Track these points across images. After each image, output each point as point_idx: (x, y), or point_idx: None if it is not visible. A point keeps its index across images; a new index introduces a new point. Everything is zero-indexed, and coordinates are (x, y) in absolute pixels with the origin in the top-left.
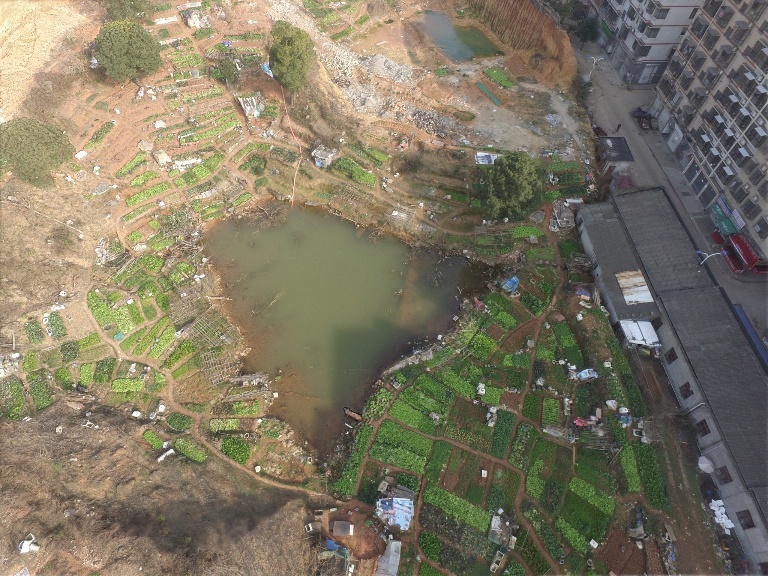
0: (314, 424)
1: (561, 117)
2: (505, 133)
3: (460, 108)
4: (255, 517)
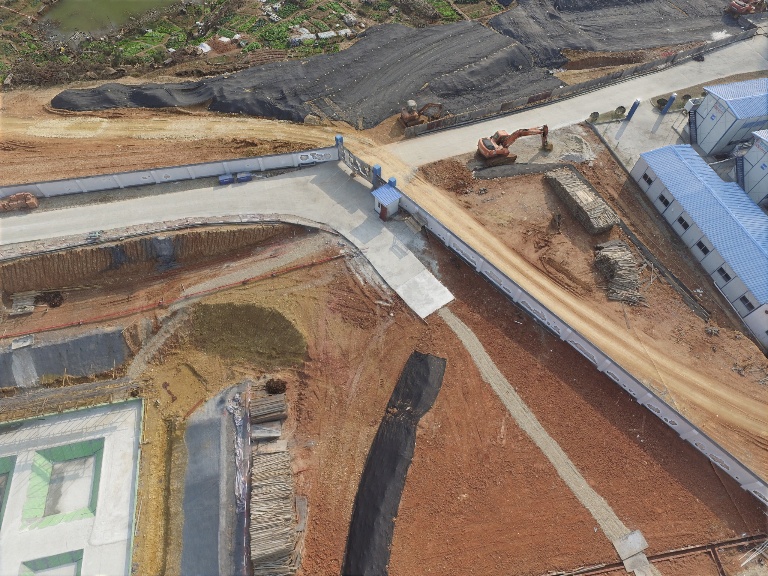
0: None
1: None
2: None
3: None
4: None
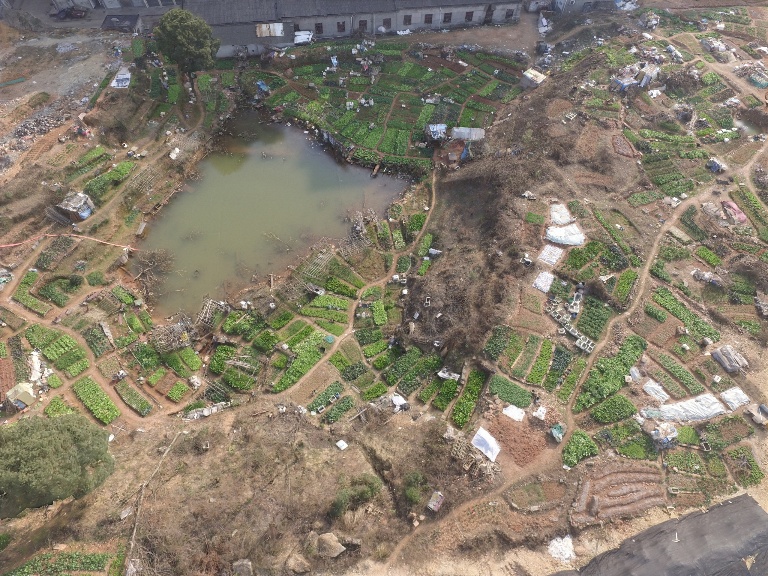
0: (385, 193)
1: (64, 42)
2: (78, 76)
3: (21, 104)
4: (461, 189)
